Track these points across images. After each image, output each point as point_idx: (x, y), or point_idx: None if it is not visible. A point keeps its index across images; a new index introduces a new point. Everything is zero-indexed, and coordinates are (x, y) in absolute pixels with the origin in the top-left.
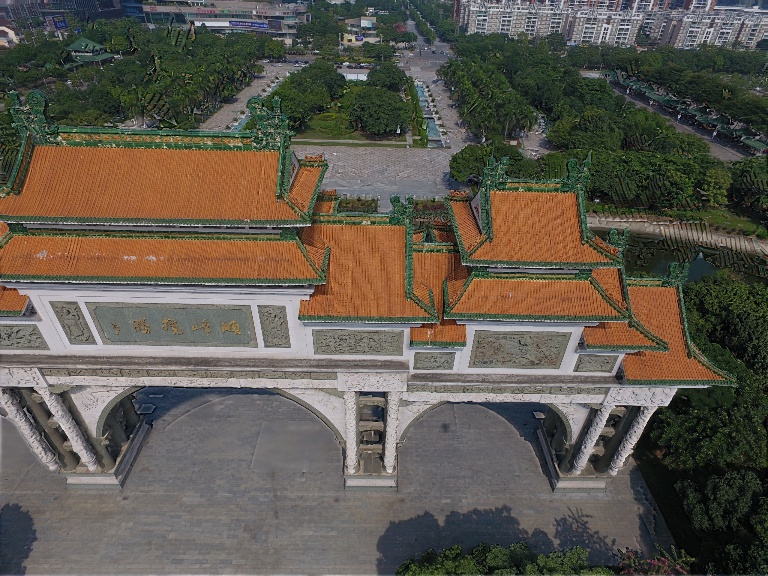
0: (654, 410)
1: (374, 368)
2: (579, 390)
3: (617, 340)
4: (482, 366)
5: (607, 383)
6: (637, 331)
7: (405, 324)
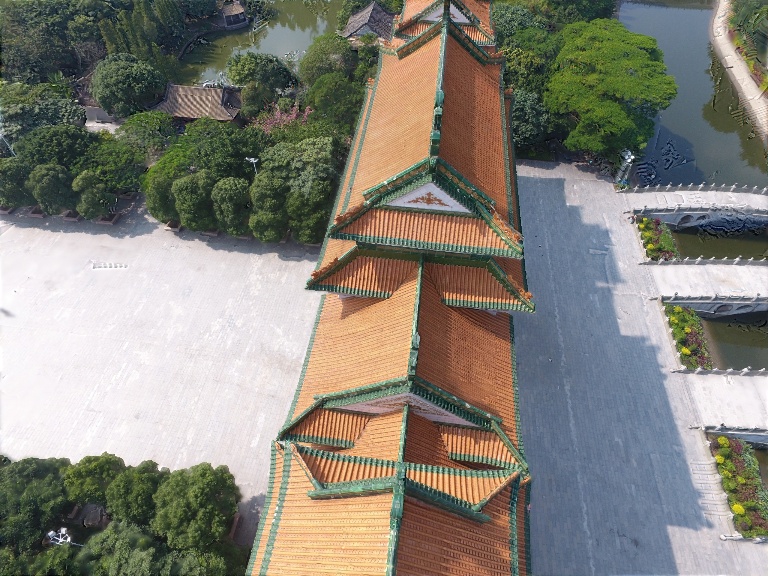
0: None
1: None
2: None
3: None
4: None
5: None
6: None
7: None
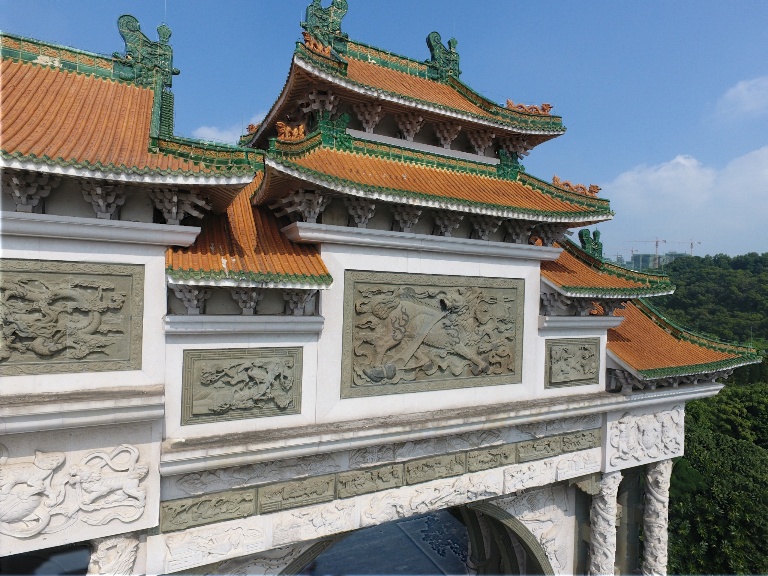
0: (669, 472)
1: (18, 403)
2: (561, 443)
3: (598, 284)
4: (372, 391)
5: (607, 397)
6: (612, 276)
7: (146, 223)
